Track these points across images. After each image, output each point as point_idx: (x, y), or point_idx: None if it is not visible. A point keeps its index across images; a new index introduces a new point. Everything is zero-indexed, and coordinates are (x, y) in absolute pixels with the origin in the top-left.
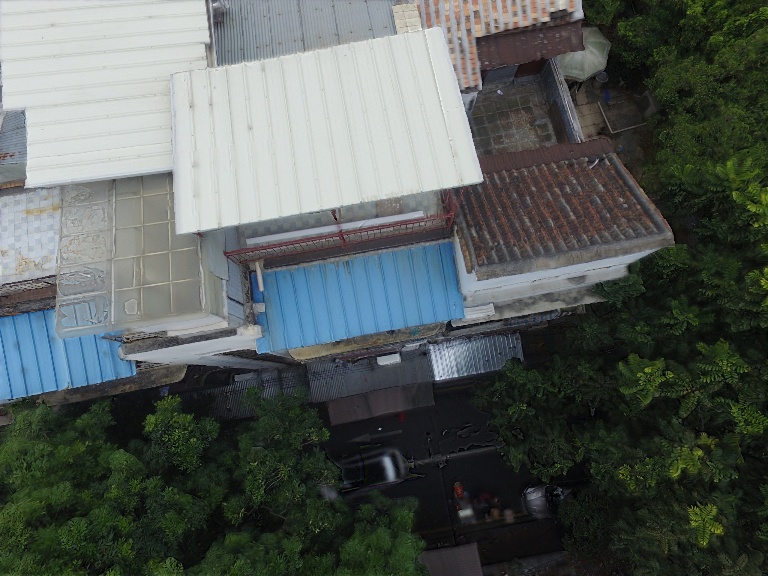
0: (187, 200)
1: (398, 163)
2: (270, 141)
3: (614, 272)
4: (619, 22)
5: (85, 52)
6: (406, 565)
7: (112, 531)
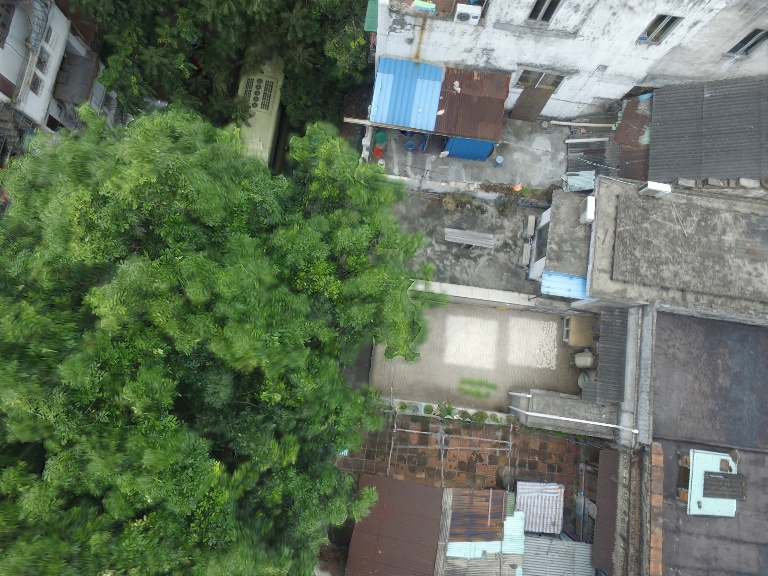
0: None
1: None
2: None
3: None
4: None
5: None
6: None
7: None
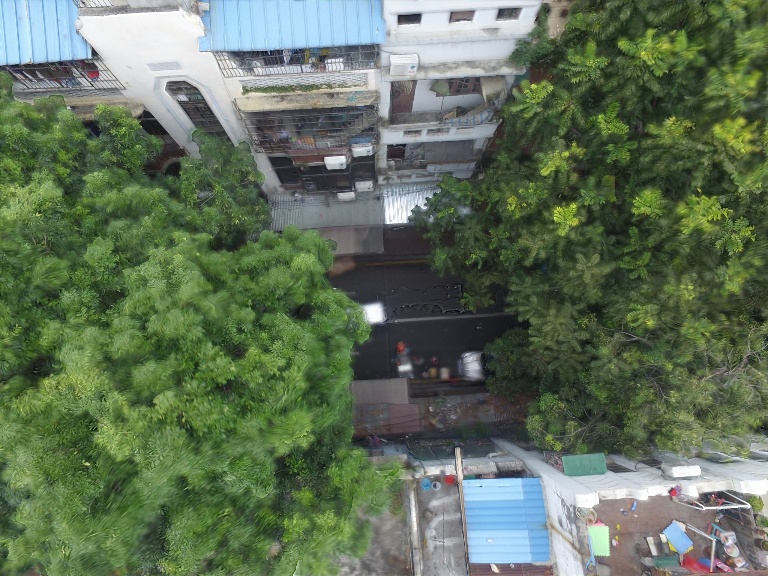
0: None
1: None
2: None
3: (525, 28)
4: None
5: None
6: (309, 246)
7: (52, 156)
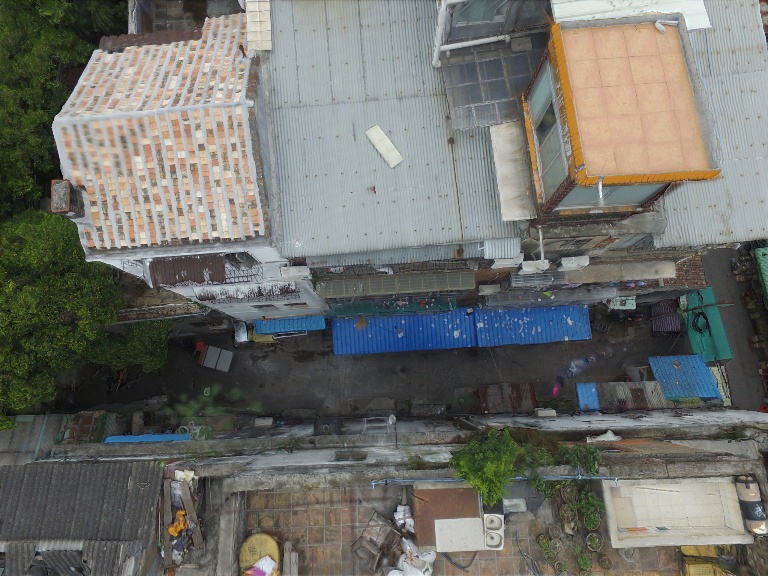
0: None
1: None
2: None
3: None
4: None
5: None
6: None
7: None
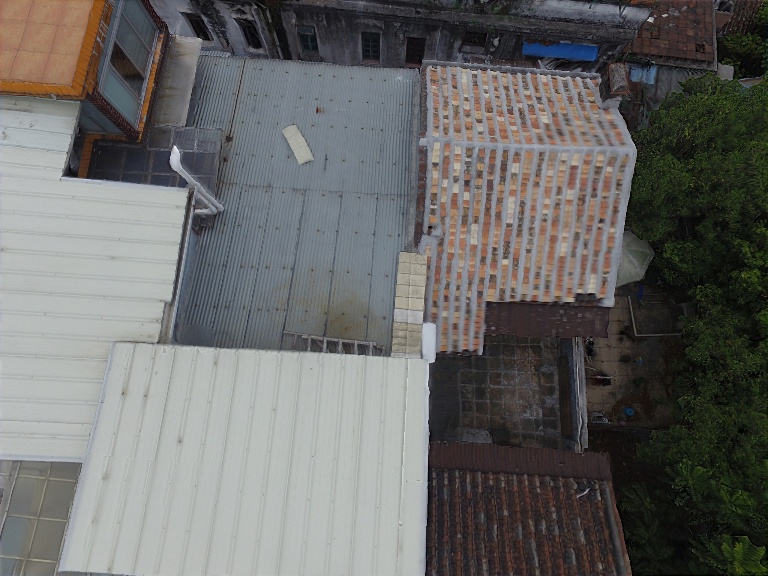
0: (83, 525)
1: (332, 540)
2: (197, 466)
3: None
4: (667, 241)
5: (29, 290)
6: None
7: None
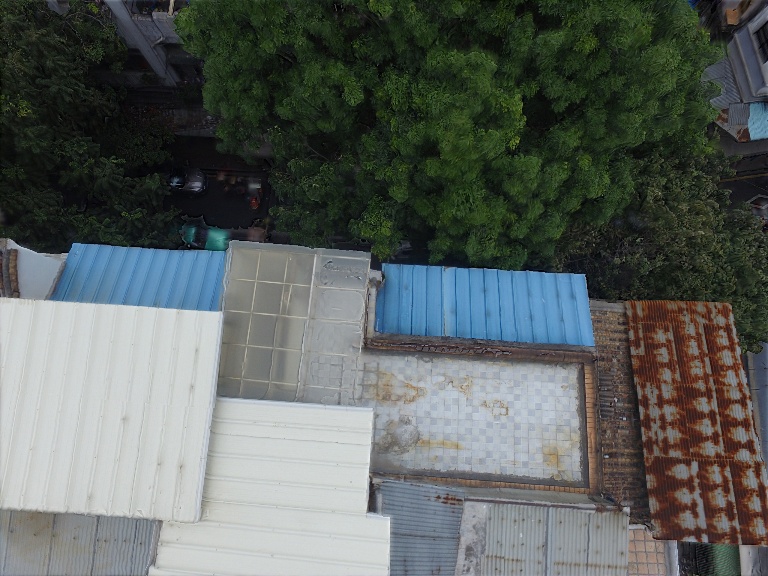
0: (205, 348)
1: None
2: (105, 397)
3: None
4: None
5: None
6: (209, 86)
7: None
